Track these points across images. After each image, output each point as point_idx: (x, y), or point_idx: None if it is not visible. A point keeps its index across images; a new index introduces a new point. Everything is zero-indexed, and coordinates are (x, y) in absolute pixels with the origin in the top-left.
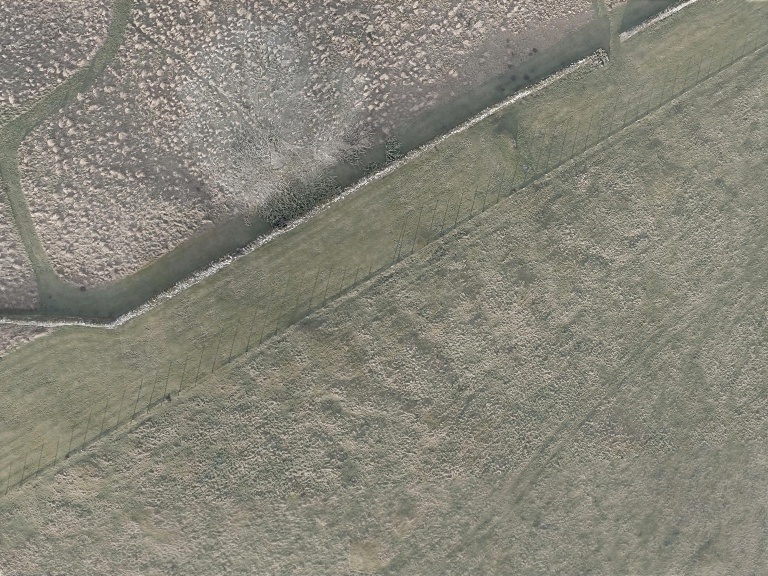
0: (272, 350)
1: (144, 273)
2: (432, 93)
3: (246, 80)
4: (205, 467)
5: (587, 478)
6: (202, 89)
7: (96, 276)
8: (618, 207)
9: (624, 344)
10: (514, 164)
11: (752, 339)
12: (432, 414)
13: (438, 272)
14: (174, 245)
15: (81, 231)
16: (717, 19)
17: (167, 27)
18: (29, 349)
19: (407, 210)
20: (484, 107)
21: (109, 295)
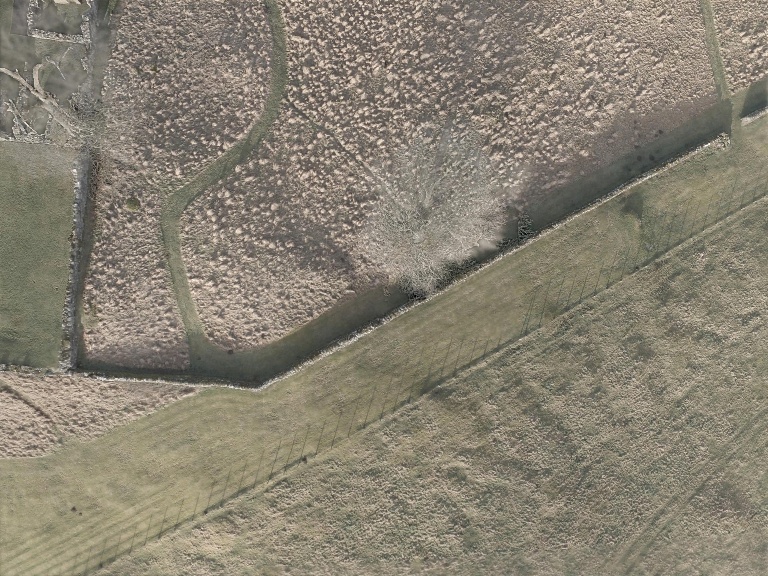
0: (405, 417)
1: (289, 339)
2: (563, 172)
3: (390, 156)
4: (335, 528)
5: (695, 552)
6: (349, 163)
7: (244, 340)
8: (733, 286)
9: (734, 420)
10: (638, 243)
11: None
12: (551, 484)
13: (562, 345)
14: (319, 313)
15: (233, 297)
16: None
17: (318, 103)
18: (176, 407)
19: (536, 285)
20: (611, 186)
21: (255, 359)
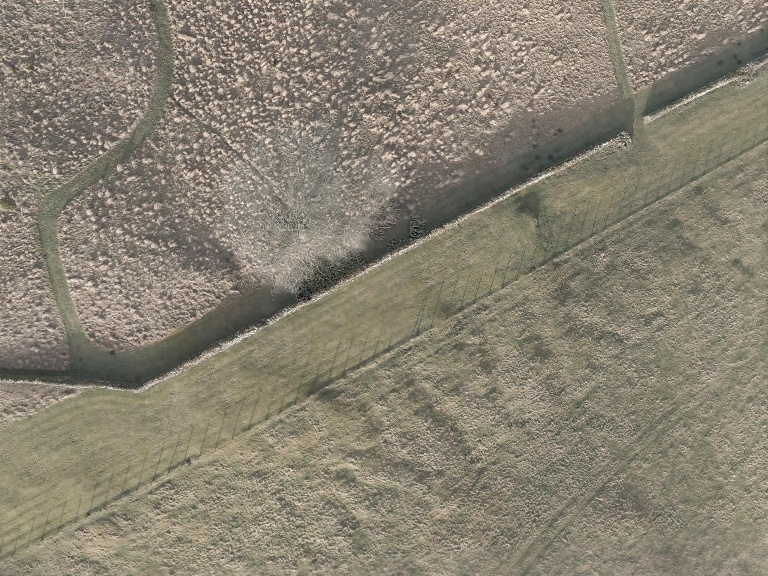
0: (291, 418)
1: (172, 340)
2: (457, 171)
3: (278, 155)
4: (221, 530)
5: (594, 554)
6: (236, 163)
7: (126, 341)
8: (635, 286)
9: (636, 421)
10: (535, 242)
11: (764, 419)
12: (444, 486)
13: (456, 346)
14: (202, 314)
15: (114, 297)
16: (740, 104)
17: (205, 102)
18: (58, 409)
19: (428, 285)
20: (507, 186)
21: (137, 360)
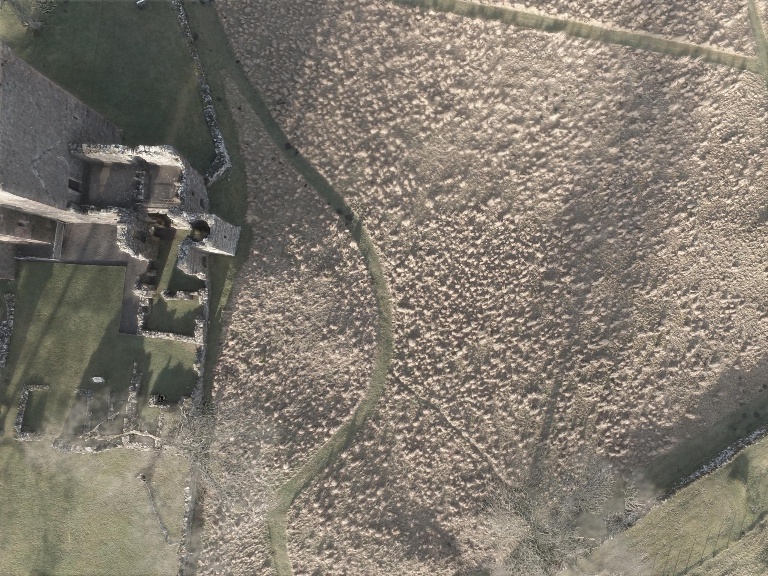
0: None
1: None
2: (670, 438)
3: (497, 430)
4: None
5: None
6: (456, 440)
7: None
8: None
9: None
10: (744, 507)
11: None
12: None
13: None
14: None
15: None
16: None
17: (424, 376)
18: None
19: (642, 558)
20: (717, 448)
21: None
